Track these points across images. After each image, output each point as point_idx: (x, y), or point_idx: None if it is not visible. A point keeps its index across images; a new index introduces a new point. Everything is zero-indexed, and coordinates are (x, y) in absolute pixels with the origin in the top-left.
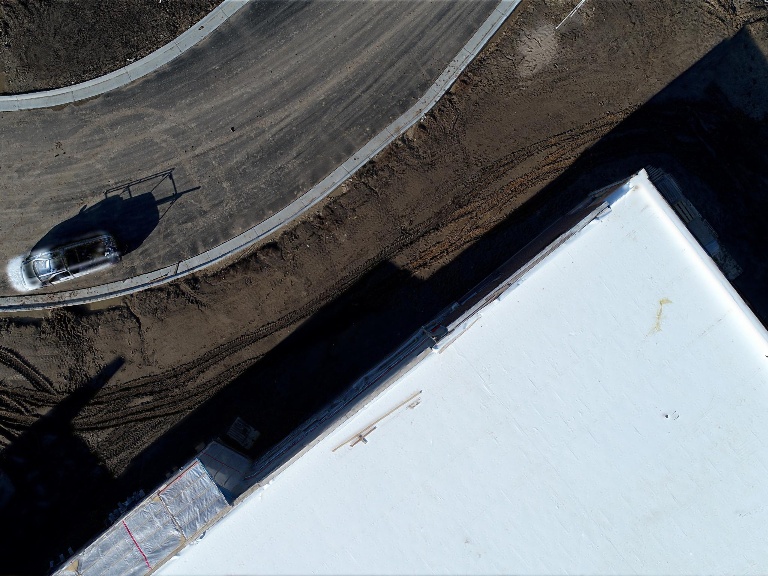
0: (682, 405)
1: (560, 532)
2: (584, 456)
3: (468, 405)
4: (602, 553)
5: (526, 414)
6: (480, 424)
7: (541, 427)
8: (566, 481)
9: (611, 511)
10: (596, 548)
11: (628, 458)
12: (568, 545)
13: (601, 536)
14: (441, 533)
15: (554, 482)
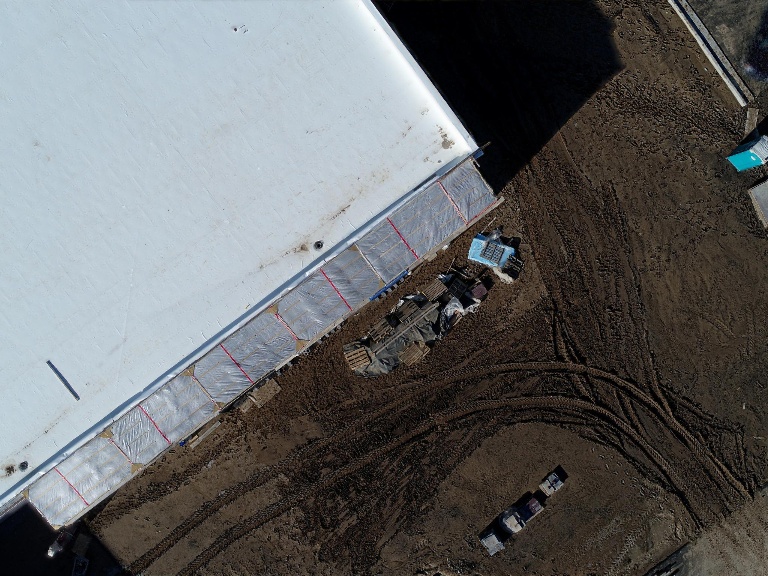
0: (251, 19)
1: (128, 139)
2: (153, 65)
3: (38, 7)
4: (170, 163)
5: (95, 20)
6: (50, 27)
7: (110, 33)
8: (135, 89)
9: (179, 121)
10: (164, 157)
11: (196, 69)
12: (136, 152)
13: (169, 146)
14: (11, 134)
15: (123, 89)
